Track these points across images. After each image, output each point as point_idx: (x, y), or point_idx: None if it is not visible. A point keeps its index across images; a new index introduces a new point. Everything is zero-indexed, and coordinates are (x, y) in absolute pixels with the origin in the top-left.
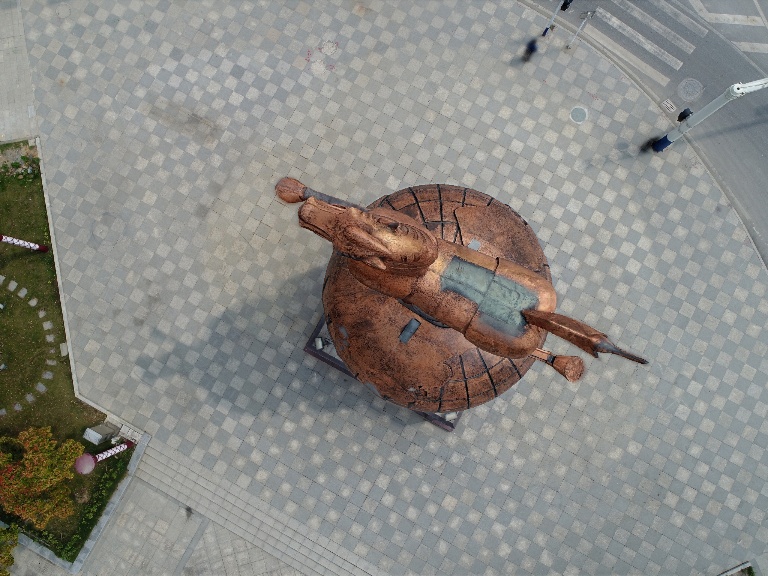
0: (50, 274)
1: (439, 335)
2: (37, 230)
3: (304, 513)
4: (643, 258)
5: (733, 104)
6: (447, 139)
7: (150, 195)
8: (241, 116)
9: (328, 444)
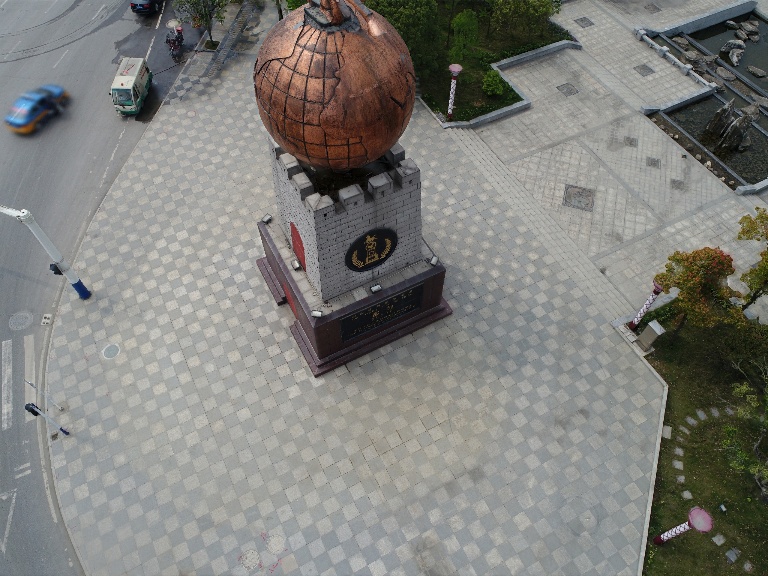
0: (660, 512)
1: (351, 5)
2: (661, 568)
3: (514, 222)
4: (171, 236)
5: (8, 293)
6: (222, 398)
7: (520, 524)
8: (384, 546)
9: (472, 249)
